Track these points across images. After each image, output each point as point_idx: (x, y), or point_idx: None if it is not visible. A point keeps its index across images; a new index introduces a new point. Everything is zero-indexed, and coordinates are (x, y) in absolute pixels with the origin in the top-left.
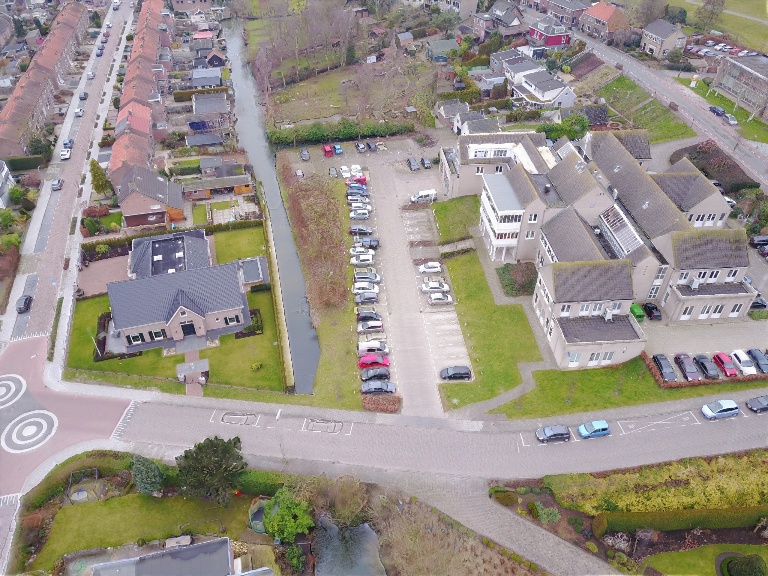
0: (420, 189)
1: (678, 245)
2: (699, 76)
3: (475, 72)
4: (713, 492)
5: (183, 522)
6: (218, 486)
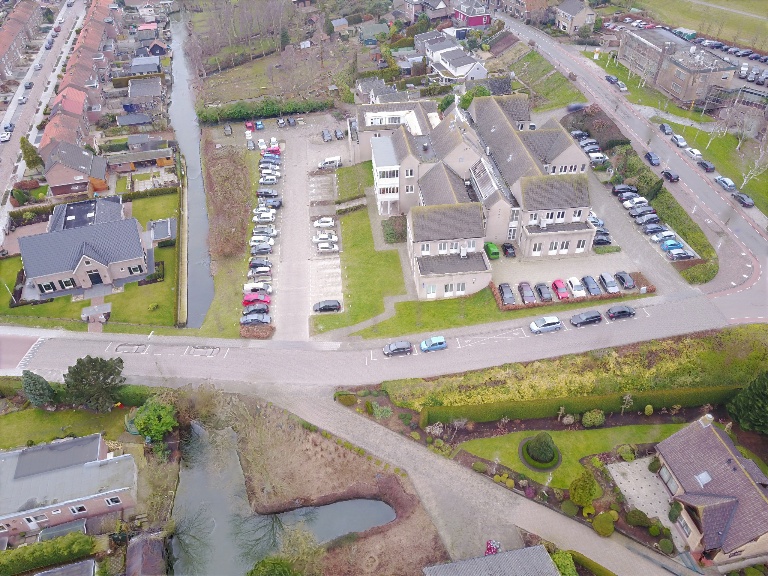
0: (329, 157)
1: (526, 189)
2: (607, 50)
3: (400, 53)
4: (527, 390)
5: (70, 428)
6: (98, 396)
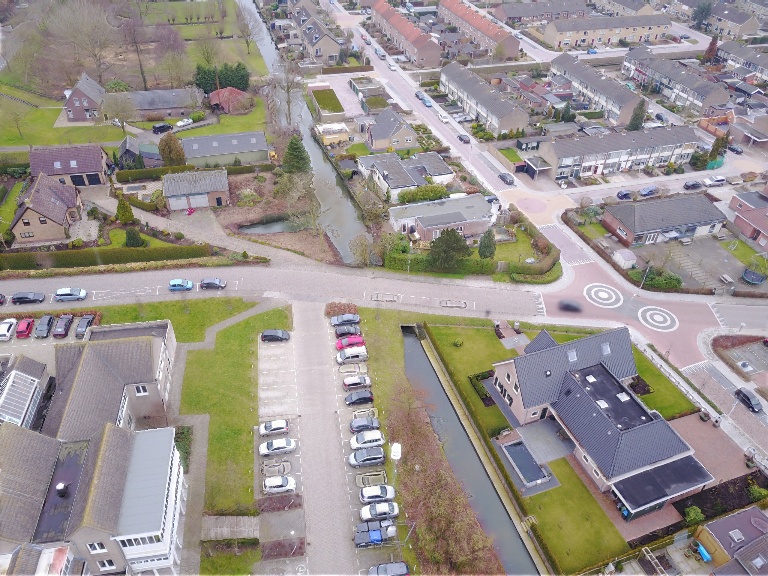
0: None
1: None
2: None
3: None
4: None
5: None
6: None
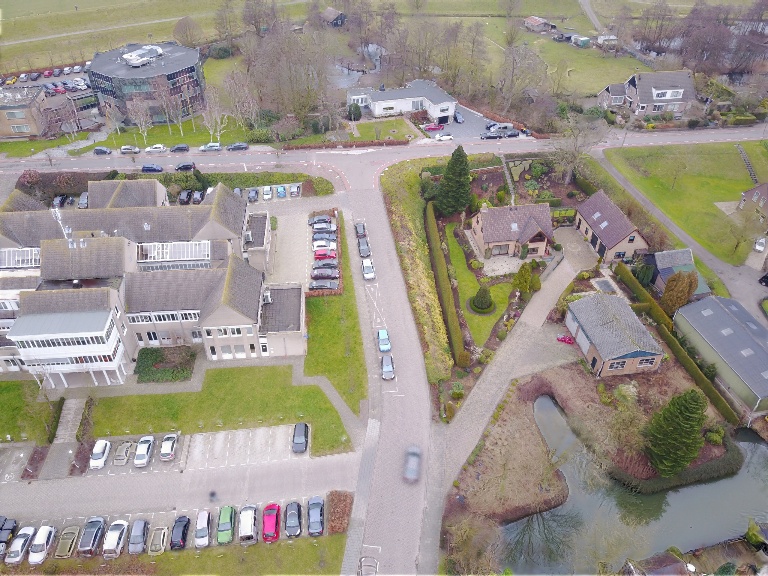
0: None
1: (222, 222)
2: None
3: None
4: (431, 296)
5: None
6: None
